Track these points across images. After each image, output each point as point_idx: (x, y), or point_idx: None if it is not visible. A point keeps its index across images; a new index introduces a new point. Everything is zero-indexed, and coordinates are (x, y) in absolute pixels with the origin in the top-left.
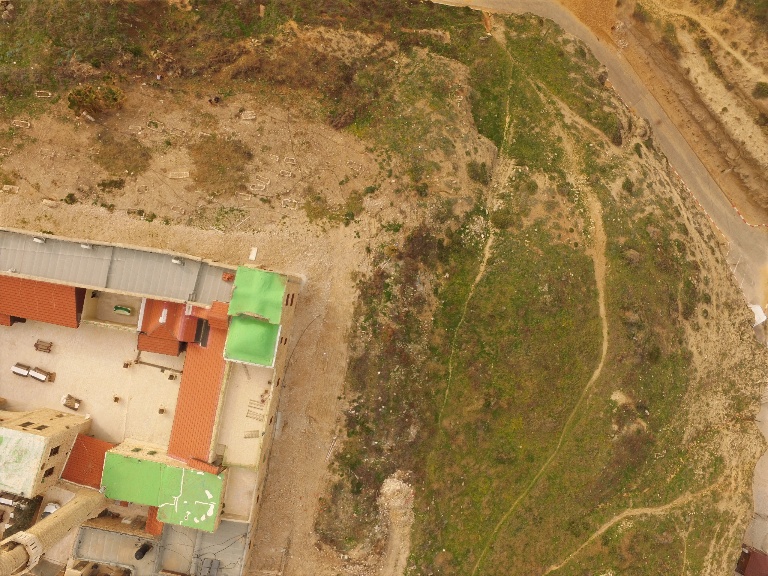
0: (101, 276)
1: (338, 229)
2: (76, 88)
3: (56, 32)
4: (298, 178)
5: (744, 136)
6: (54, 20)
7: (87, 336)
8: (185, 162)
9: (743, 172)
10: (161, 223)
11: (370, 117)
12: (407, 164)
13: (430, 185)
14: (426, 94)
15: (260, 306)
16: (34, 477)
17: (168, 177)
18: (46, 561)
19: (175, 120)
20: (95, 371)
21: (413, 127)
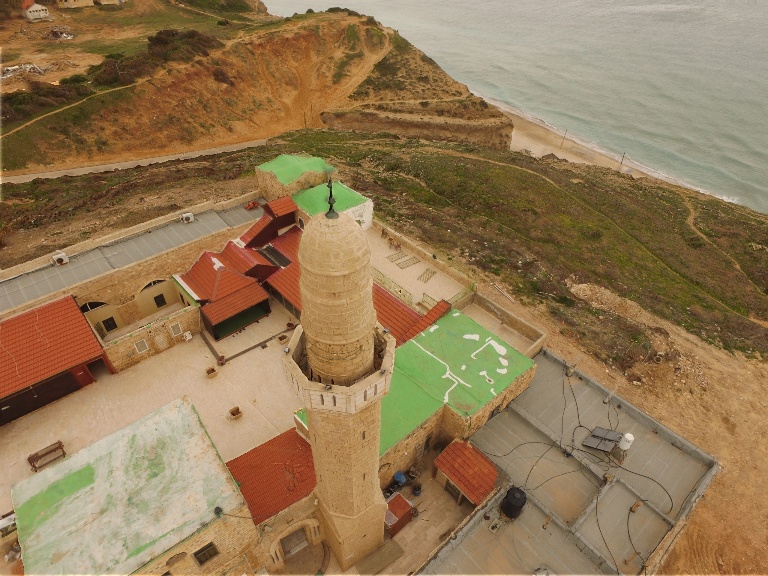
0: (103, 271)
1: None
2: None
3: None
4: None
5: (442, 121)
6: None
7: (119, 394)
8: None
9: (463, 138)
10: None
11: None
12: None
13: None
14: None
15: (307, 168)
16: (216, 464)
17: None
18: None
19: None
20: None
21: None
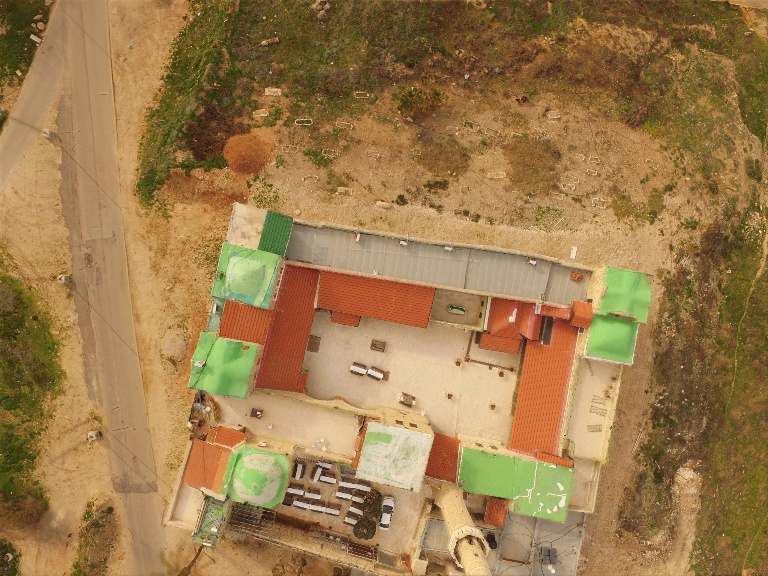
0: (460, 277)
1: (644, 227)
2: (391, 88)
3: (372, 32)
4: (603, 177)
5: None
6: (370, 20)
7: (418, 335)
8: (501, 162)
9: None
10: (486, 223)
11: (660, 115)
12: (698, 162)
13: (718, 182)
14: (705, 91)
15: (630, 305)
16: (422, 473)
17: (487, 177)
18: (380, 552)
19: (488, 120)
20: (426, 369)
21: (698, 124)
